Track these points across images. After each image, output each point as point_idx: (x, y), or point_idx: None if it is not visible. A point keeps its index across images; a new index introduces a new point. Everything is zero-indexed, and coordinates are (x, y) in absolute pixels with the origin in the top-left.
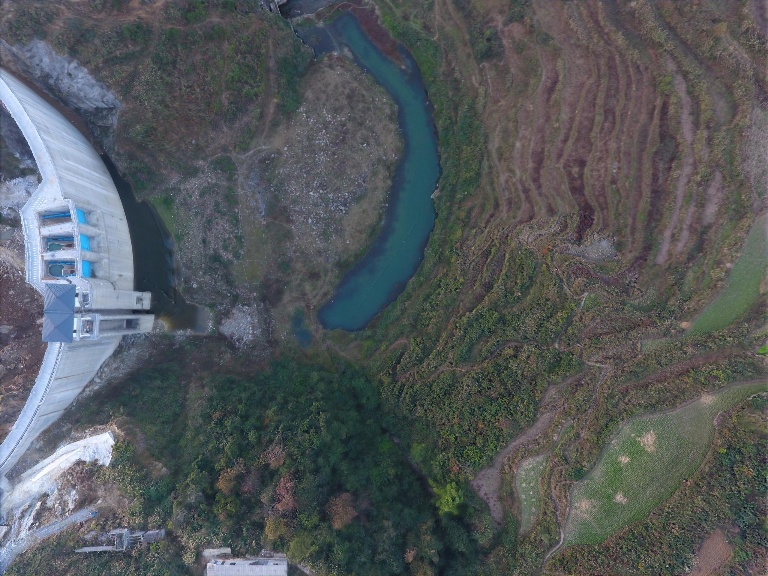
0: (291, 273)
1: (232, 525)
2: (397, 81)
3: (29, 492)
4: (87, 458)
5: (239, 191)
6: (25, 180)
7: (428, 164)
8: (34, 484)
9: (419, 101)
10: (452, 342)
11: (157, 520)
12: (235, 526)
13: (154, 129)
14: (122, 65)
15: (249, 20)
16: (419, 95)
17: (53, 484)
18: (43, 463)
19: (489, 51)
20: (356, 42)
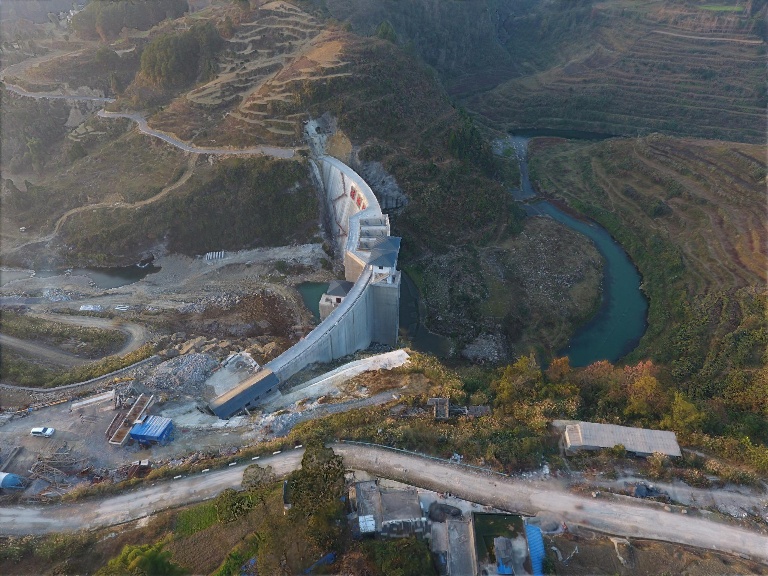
0: (528, 320)
1: (581, 401)
2: (588, 231)
3: (305, 394)
4: (378, 368)
5: (481, 263)
6: (313, 245)
7: (628, 272)
8: (313, 387)
9: (608, 241)
10: (724, 352)
11: (483, 396)
12: (582, 407)
13: (426, 219)
14: (419, 181)
15: (494, 182)
16: (607, 238)
17: (335, 389)
18: (321, 377)
19: (660, 211)
20: (553, 214)
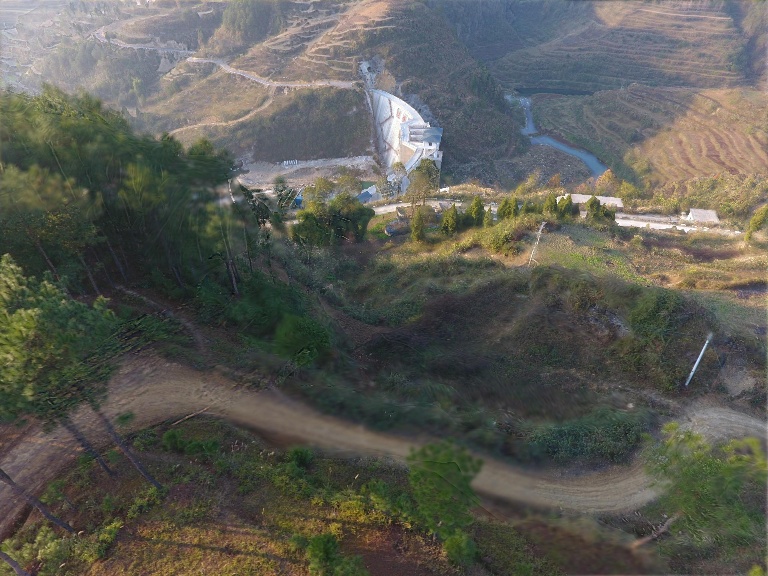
0: None
1: None
2: (579, 155)
3: None
4: None
5: None
6: (366, 156)
7: None
8: None
9: (595, 161)
10: None
11: None
12: None
13: (453, 138)
14: None
15: (505, 115)
16: None
17: None
18: None
19: (635, 137)
20: (552, 144)
